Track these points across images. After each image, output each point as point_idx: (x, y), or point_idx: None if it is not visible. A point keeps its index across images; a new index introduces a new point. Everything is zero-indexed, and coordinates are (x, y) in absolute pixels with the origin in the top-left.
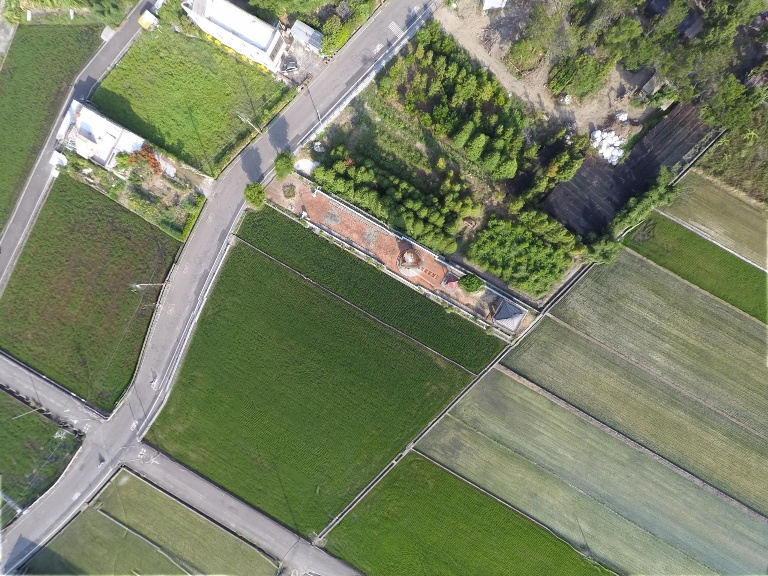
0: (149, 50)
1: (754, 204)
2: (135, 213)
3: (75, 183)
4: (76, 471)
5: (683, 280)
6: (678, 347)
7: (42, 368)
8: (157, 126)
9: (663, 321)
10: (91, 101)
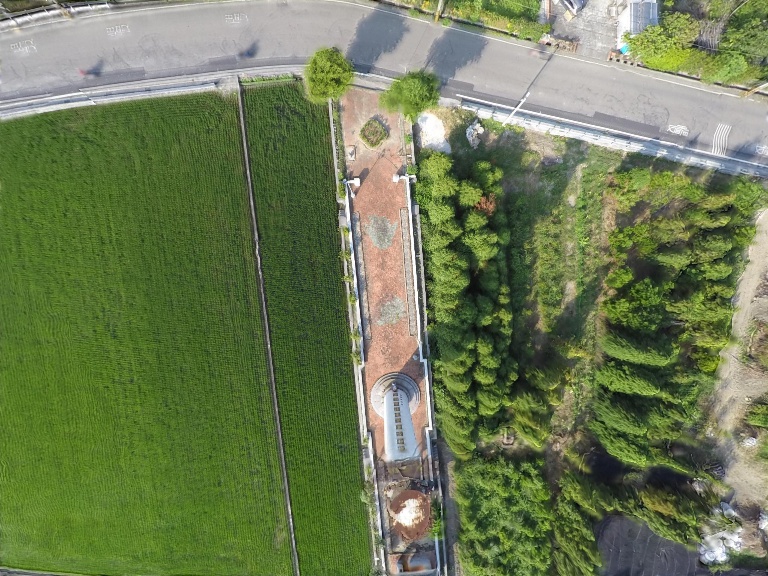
0: None
1: None
2: None
3: None
4: None
5: None
6: None
7: None
8: None
9: None
10: None
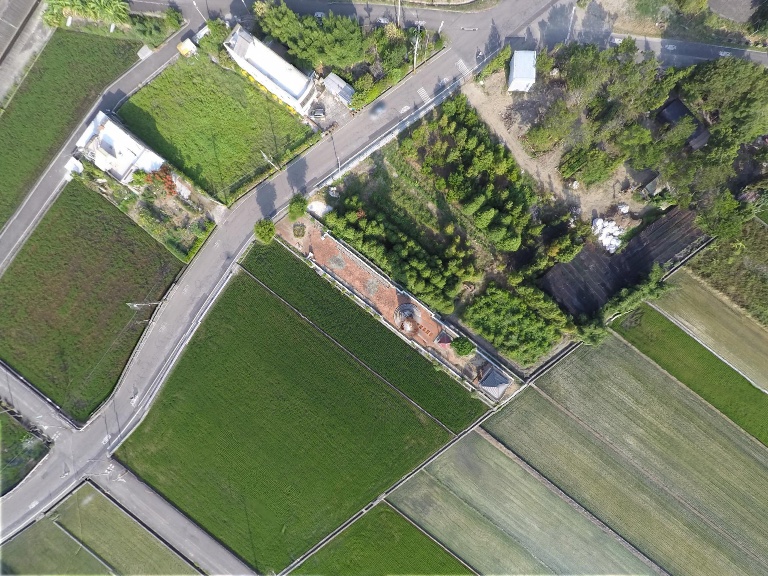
0: (183, 74)
1: (735, 308)
2: (143, 228)
3: (87, 190)
4: (38, 478)
5: (663, 370)
6: (651, 433)
7: (21, 368)
8: (179, 148)
9: (640, 406)
10: (117, 113)
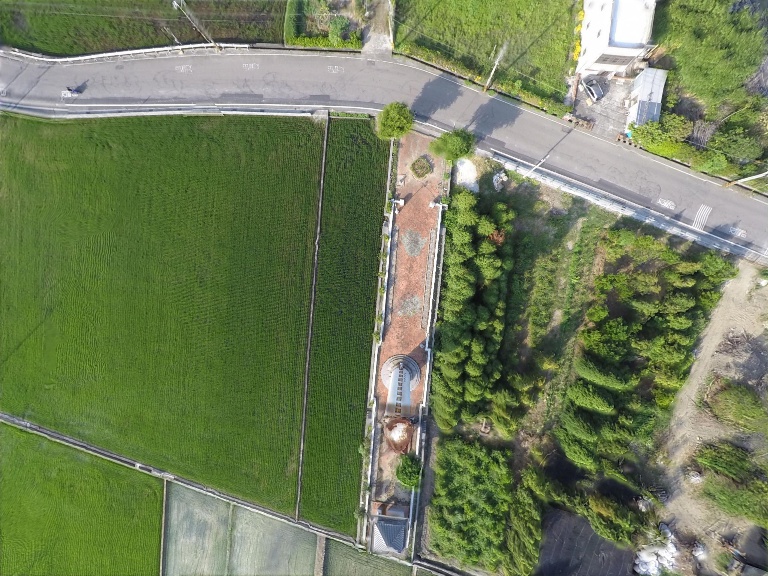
0: None
1: None
2: None
3: None
4: None
5: None
6: None
7: None
8: None
9: None
10: None
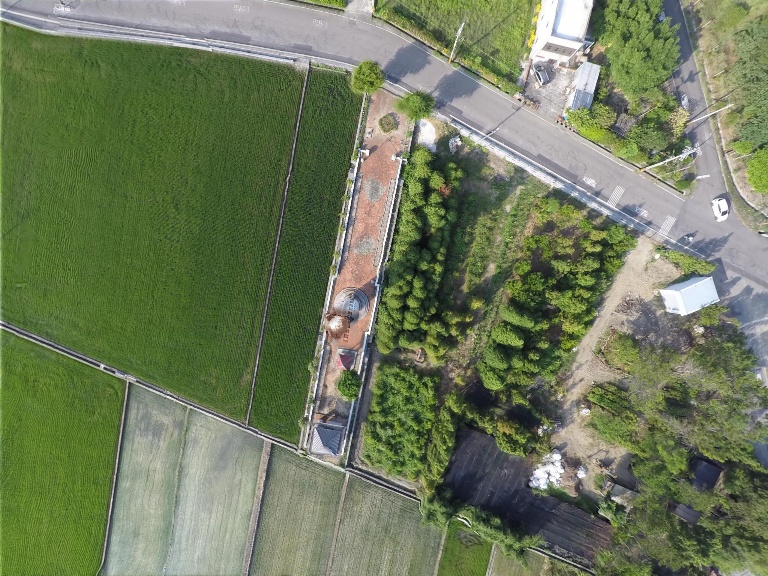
0: None
1: None
2: None
3: None
4: None
5: None
6: None
7: None
8: None
9: None
10: None
